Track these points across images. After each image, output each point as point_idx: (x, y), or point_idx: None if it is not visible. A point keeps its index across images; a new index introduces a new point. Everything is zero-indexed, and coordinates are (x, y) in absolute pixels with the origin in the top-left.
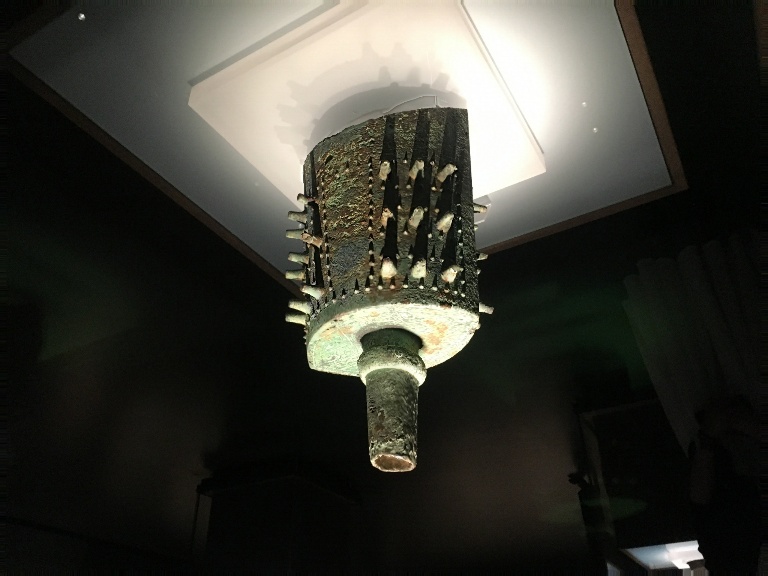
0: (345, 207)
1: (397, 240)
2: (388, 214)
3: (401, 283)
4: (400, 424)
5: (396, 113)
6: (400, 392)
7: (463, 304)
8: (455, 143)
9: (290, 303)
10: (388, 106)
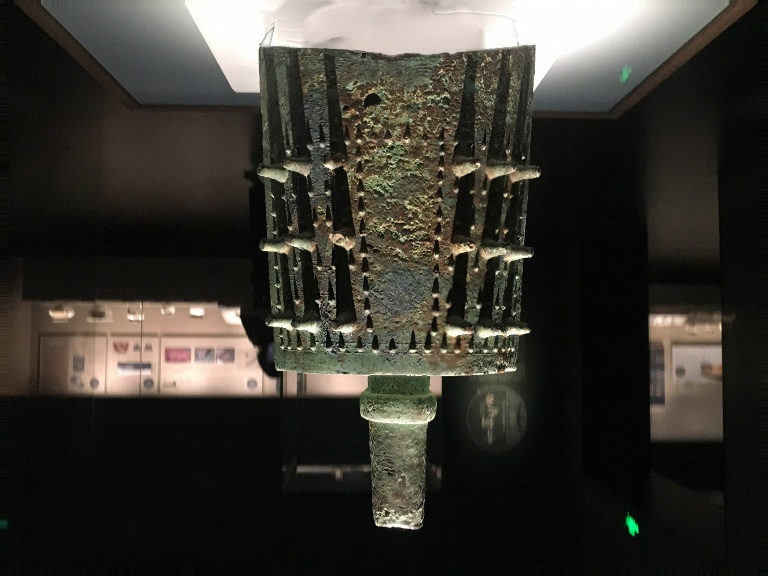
0: (401, 206)
1: (466, 279)
2: (471, 250)
3: (467, 345)
4: (420, 492)
5: (479, 52)
6: (422, 452)
7: (511, 362)
8: (526, 111)
9: (298, 326)
10: (444, 3)
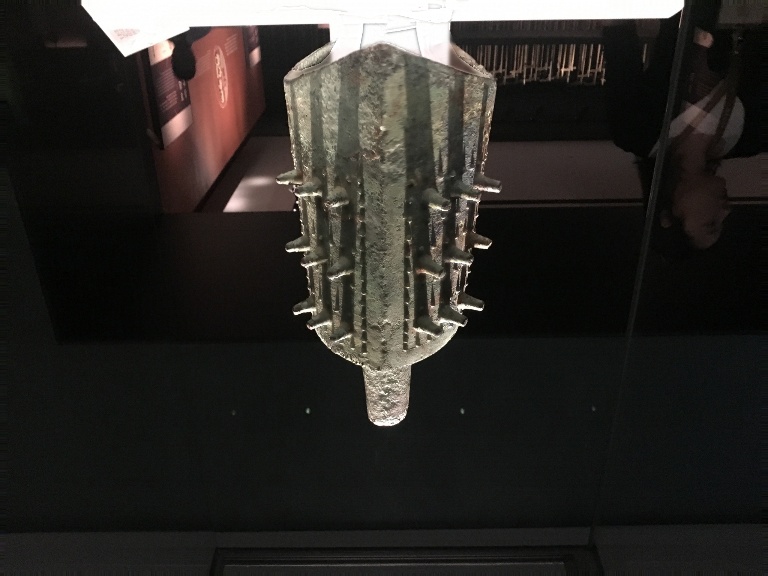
0: None
1: None
2: None
3: None
4: None
5: None
6: None
7: None
8: None
9: None
10: None
